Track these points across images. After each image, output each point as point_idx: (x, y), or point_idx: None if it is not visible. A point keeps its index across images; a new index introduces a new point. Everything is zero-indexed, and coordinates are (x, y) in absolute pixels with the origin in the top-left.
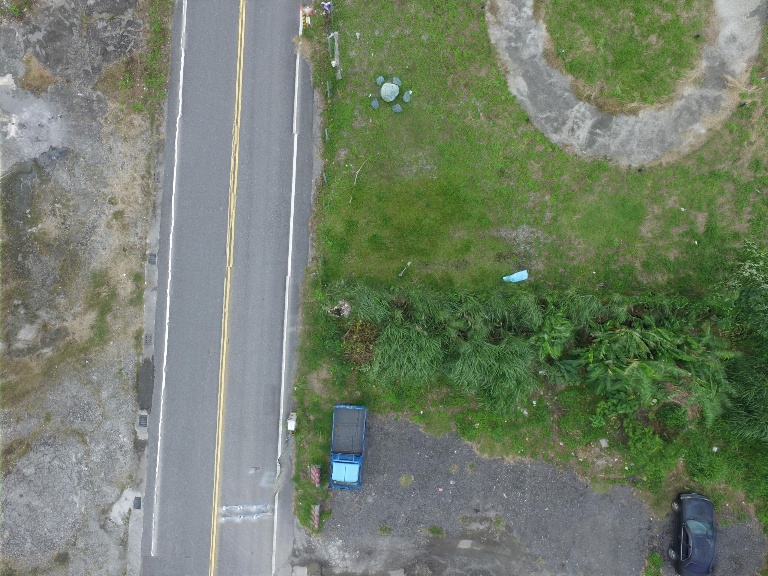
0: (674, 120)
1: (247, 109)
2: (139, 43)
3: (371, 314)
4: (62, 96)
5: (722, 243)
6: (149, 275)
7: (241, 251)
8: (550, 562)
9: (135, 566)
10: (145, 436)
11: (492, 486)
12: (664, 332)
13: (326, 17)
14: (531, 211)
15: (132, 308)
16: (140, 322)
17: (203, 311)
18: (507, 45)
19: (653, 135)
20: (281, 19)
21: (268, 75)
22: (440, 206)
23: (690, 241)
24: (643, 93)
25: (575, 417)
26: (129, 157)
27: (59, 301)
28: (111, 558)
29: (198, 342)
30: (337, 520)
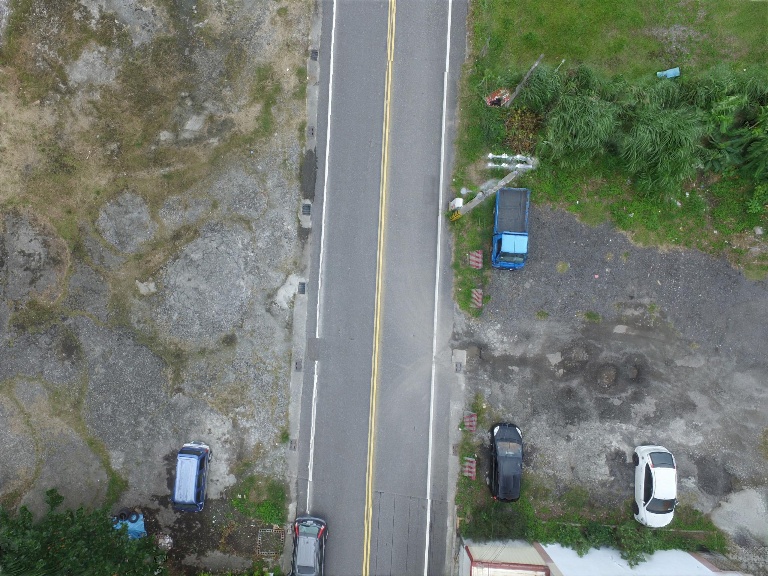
0: None
1: None
2: None
3: (540, 92)
4: None
5: None
6: (311, 70)
7: (401, 47)
8: (704, 346)
9: (300, 348)
10: (308, 224)
11: (646, 274)
12: None
13: None
14: (683, 10)
15: (295, 101)
16: (303, 115)
17: (364, 104)
18: None
19: None
20: None
21: None
22: (593, 6)
23: None
24: None
25: (729, 205)
26: None
27: (225, 94)
28: (277, 340)
29: (360, 134)
30: (496, 305)
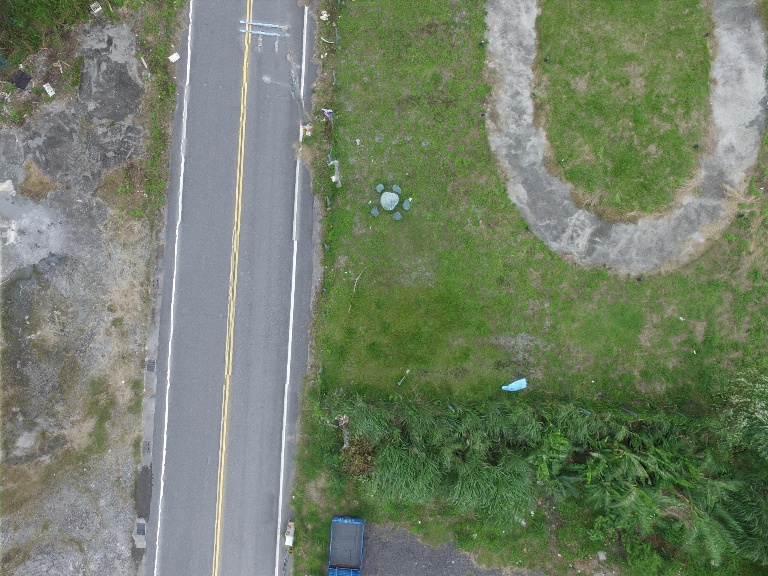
0: (673, 229)
1: (247, 216)
2: (139, 149)
3: (370, 431)
4: (62, 202)
5: (720, 353)
6: (148, 382)
7: (240, 359)
8: None
9: None
10: (143, 544)
11: None
12: (662, 453)
13: (326, 123)
14: (530, 319)
15: (130, 415)
16: (138, 429)
17: (202, 419)
18: (507, 152)
19: (652, 244)
20: (281, 125)
21: (268, 181)
22: (439, 314)
23: (688, 350)
24: (642, 202)
25: (573, 529)
26: (128, 263)
27: (57, 408)
28: None
29: (196, 450)
30: None
